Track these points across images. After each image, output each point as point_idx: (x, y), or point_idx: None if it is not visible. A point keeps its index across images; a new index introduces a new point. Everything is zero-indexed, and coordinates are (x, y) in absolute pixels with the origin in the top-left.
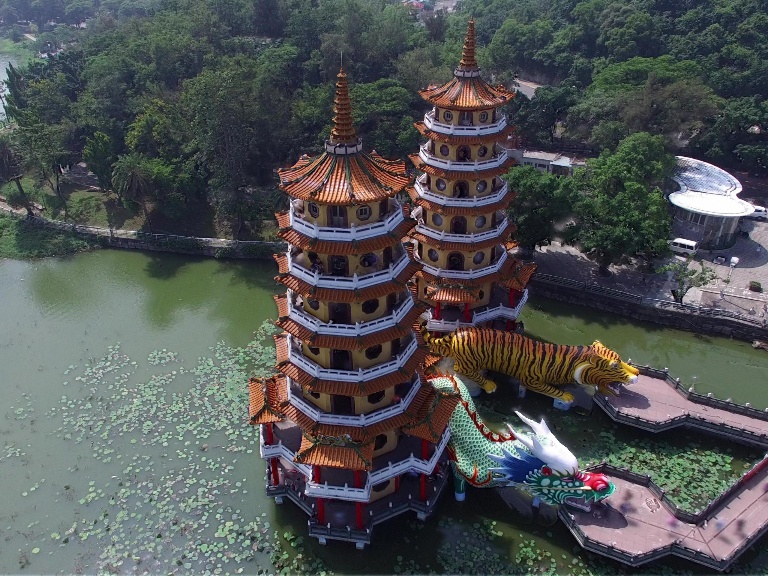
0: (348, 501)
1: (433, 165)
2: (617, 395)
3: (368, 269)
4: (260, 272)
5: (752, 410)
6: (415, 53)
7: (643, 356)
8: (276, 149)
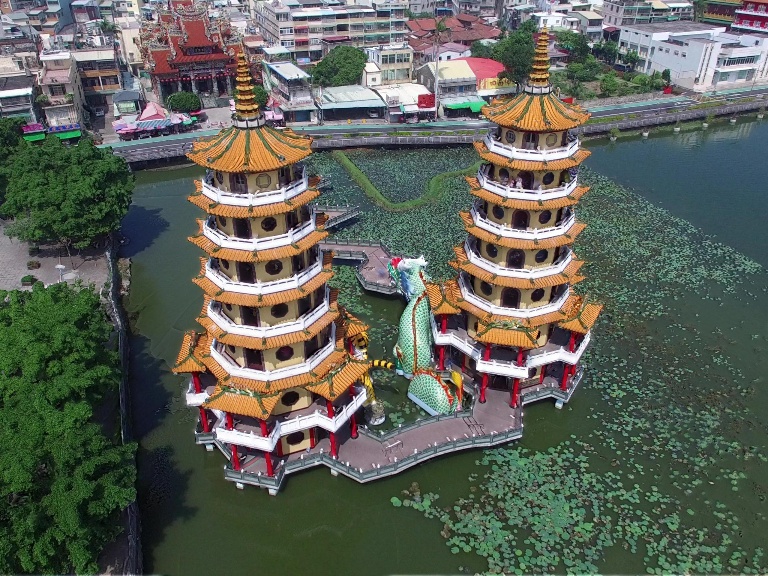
0: None
1: None
2: None
3: None
4: None
5: None
6: None
7: None
8: None
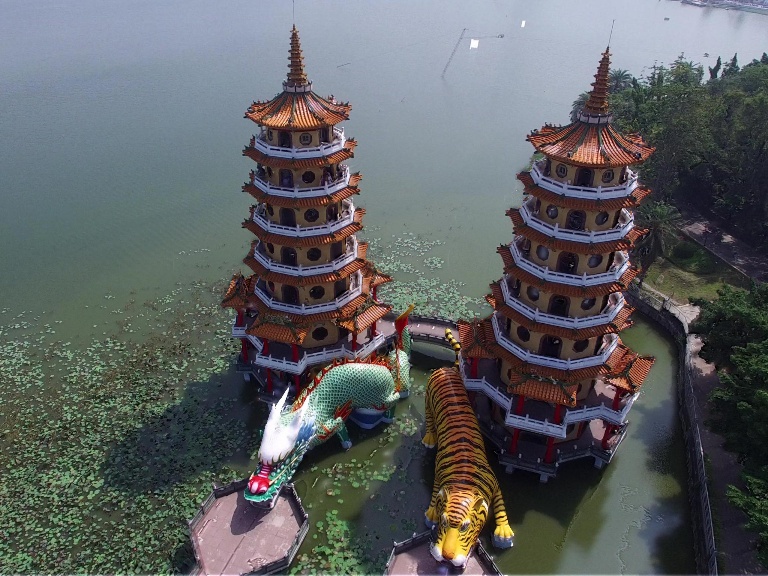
0: None
1: None
2: None
3: None
4: None
5: None
6: None
7: None
8: None
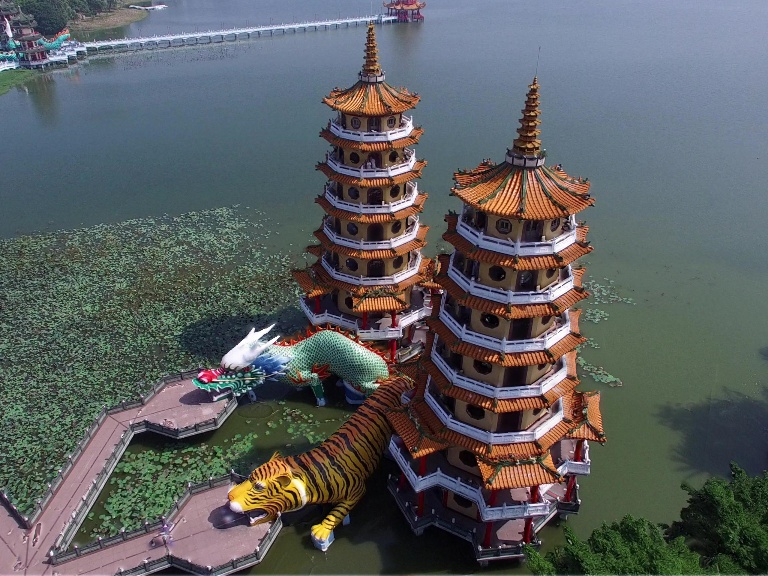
0: None
1: None
2: None
3: None
4: (762, 427)
5: None
6: None
7: None
8: None
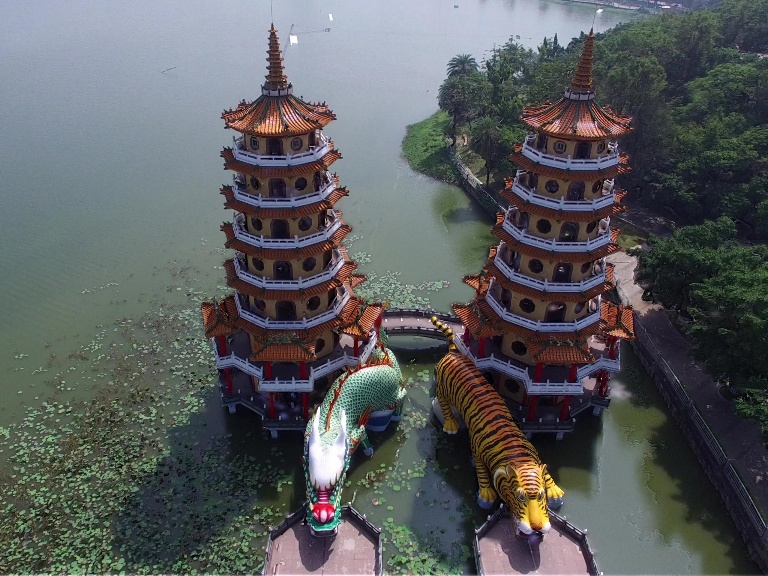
0: None
1: None
2: (516, 534)
3: (252, 190)
4: None
5: None
6: None
7: None
8: (642, 164)
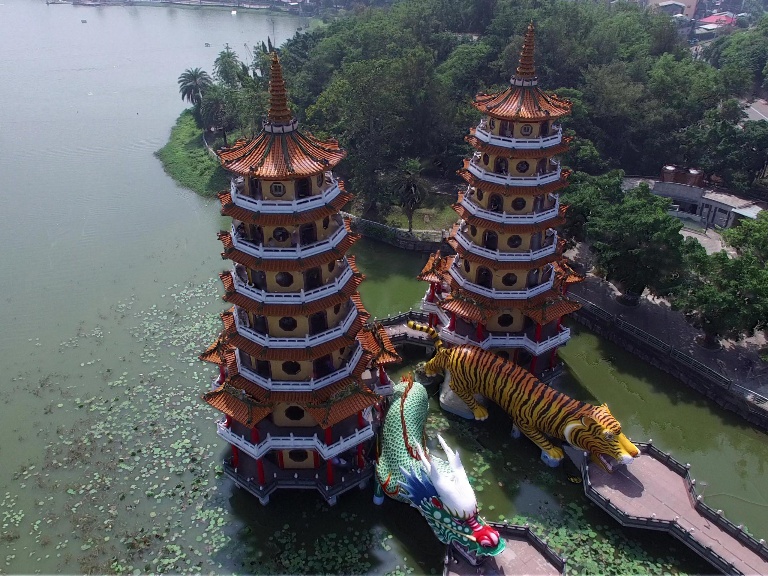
0: (245, 452)
1: (472, 172)
2: (609, 471)
3: (279, 243)
4: (369, 251)
5: (766, 550)
6: (611, 65)
7: (730, 454)
8: (435, 142)
